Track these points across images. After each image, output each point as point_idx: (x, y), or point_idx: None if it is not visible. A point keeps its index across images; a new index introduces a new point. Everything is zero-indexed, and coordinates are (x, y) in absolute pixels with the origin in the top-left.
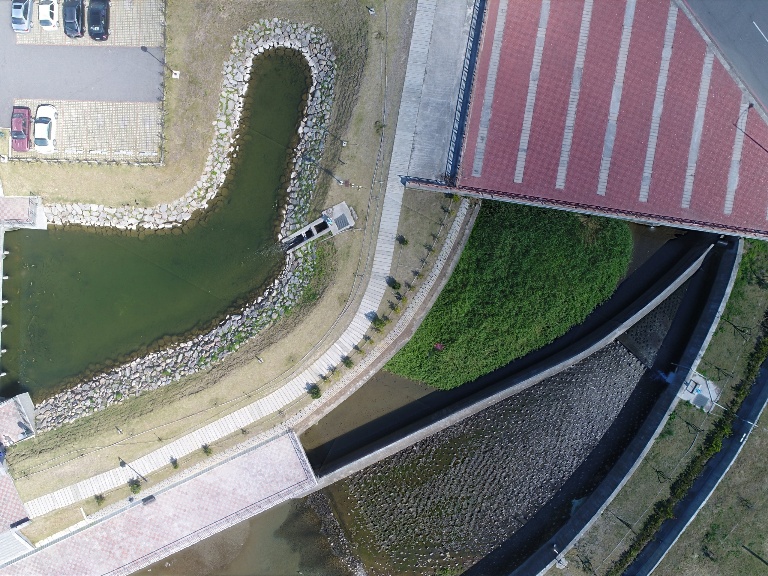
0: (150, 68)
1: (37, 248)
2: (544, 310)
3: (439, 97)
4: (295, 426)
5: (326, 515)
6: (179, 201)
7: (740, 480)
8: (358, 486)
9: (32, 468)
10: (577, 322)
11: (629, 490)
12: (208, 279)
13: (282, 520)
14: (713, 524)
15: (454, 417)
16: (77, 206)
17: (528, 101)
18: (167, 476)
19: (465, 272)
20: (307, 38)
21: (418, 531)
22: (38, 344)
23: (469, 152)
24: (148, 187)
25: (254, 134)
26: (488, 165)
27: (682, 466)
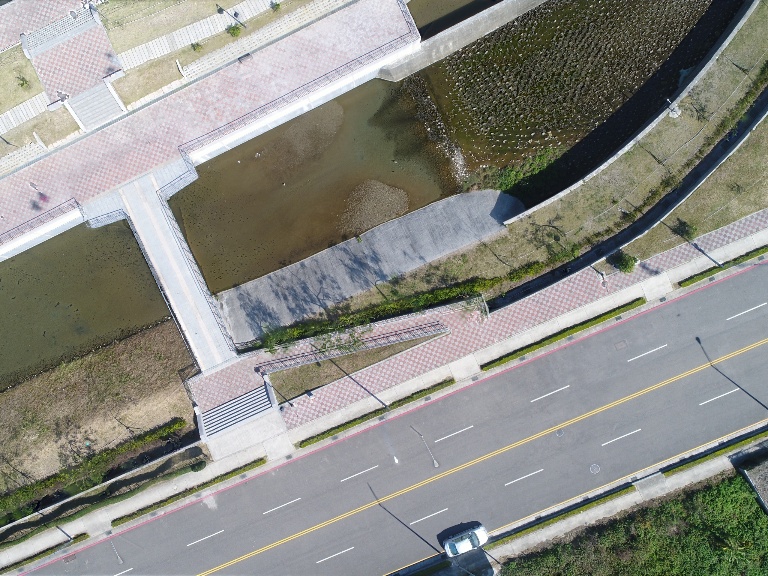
0: None
1: None
2: None
3: None
4: None
5: (423, 99)
6: None
7: None
8: (456, 67)
9: (126, 18)
10: None
11: (745, 34)
12: None
13: (376, 107)
14: None
15: None
16: None
17: None
18: (267, 22)
19: None
20: None
21: (519, 111)
22: None
23: None
24: None
25: None
26: None
27: None
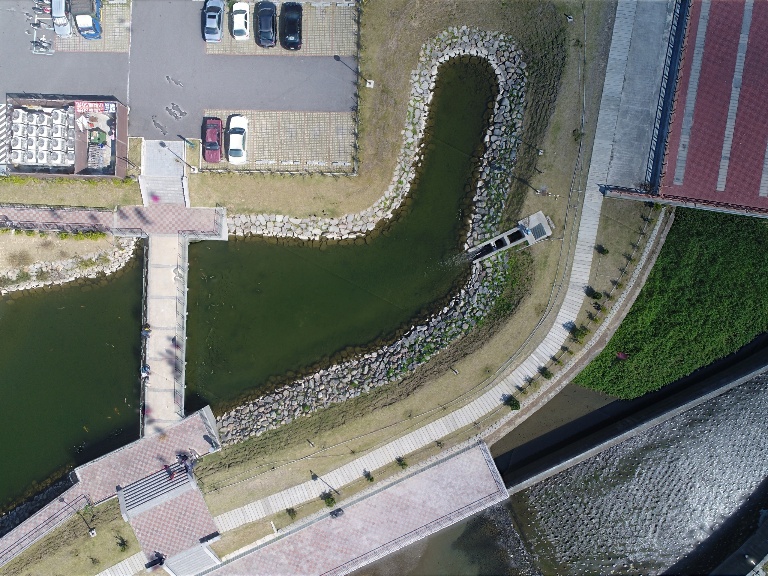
0: (343, 77)
1: (216, 259)
2: (732, 318)
3: (638, 105)
4: (486, 438)
5: (506, 526)
6: (366, 211)
7: None
8: (539, 497)
9: (222, 482)
10: (763, 330)
11: None
12: (390, 289)
13: (460, 532)
14: None
15: (642, 427)
16: (262, 217)
17: (730, 108)
18: (360, 489)
19: (651, 281)
20: (495, 46)
21: (601, 542)
22: (217, 356)
23: (670, 160)
24: (338, 197)
25: (437, 143)
26: (690, 173)
27: None
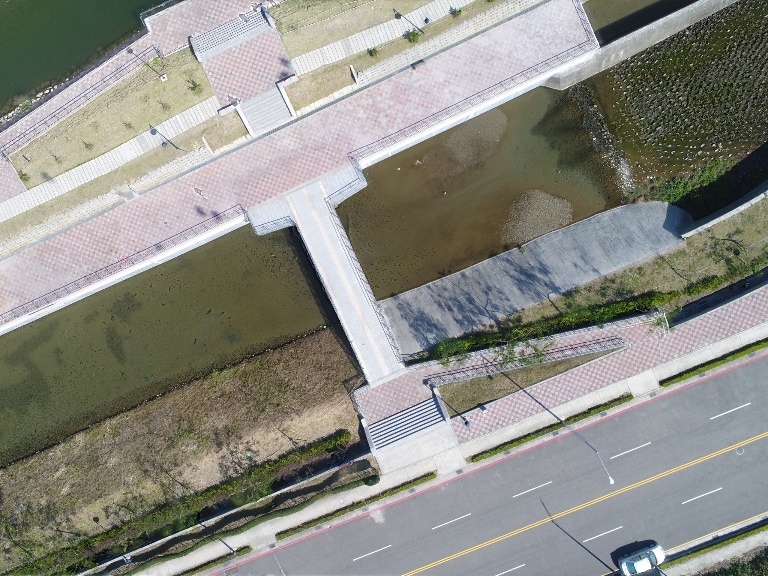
0: None
1: None
2: None
3: None
4: None
5: (589, 108)
6: None
7: None
8: (624, 76)
9: (300, 22)
10: None
11: None
12: None
13: (541, 115)
14: None
15: None
16: None
17: None
18: (445, 28)
19: None
20: None
21: (688, 122)
22: None
23: None
24: None
25: None
26: None
27: None
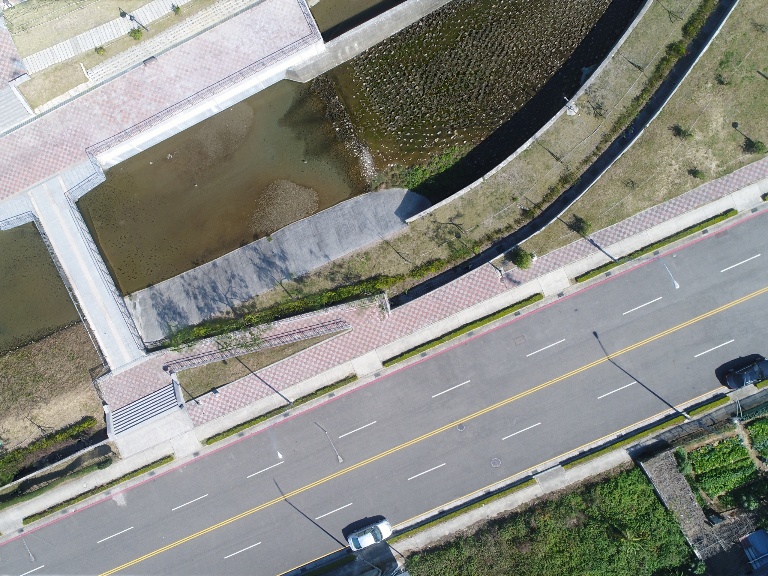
0: None
1: None
2: None
3: None
4: None
5: (331, 99)
6: None
7: (754, 6)
8: (363, 67)
9: (31, 22)
10: None
11: (640, 32)
12: None
13: (286, 108)
14: (727, 52)
15: None
16: None
17: None
18: (169, 25)
19: None
20: None
21: (425, 110)
22: None
23: None
24: None
25: None
26: None
27: (694, 6)
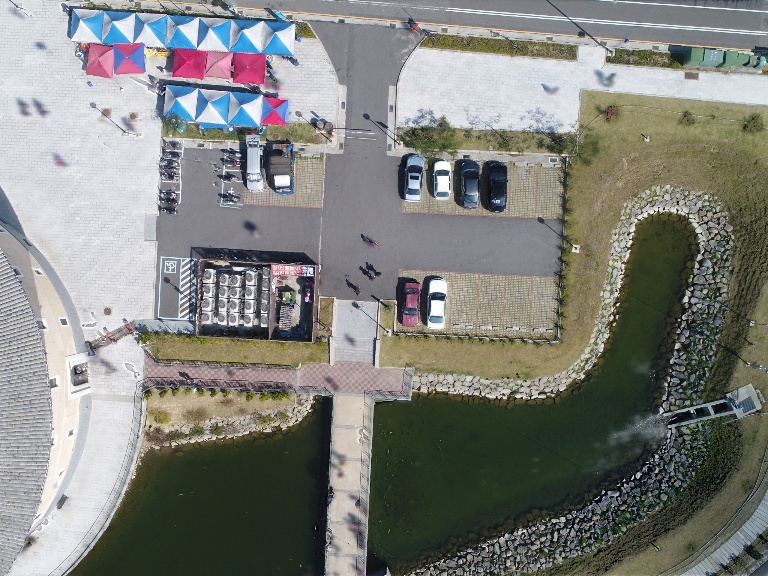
0: (547, 241)
1: (397, 415)
2: None
3: None
4: None
5: None
6: (560, 373)
7: None
8: None
9: None
10: None
11: None
12: (578, 450)
13: None
14: None
15: None
16: (451, 377)
17: None
18: None
19: None
20: (698, 205)
21: None
22: (394, 514)
23: None
24: (535, 362)
25: (631, 301)
26: None
27: None
